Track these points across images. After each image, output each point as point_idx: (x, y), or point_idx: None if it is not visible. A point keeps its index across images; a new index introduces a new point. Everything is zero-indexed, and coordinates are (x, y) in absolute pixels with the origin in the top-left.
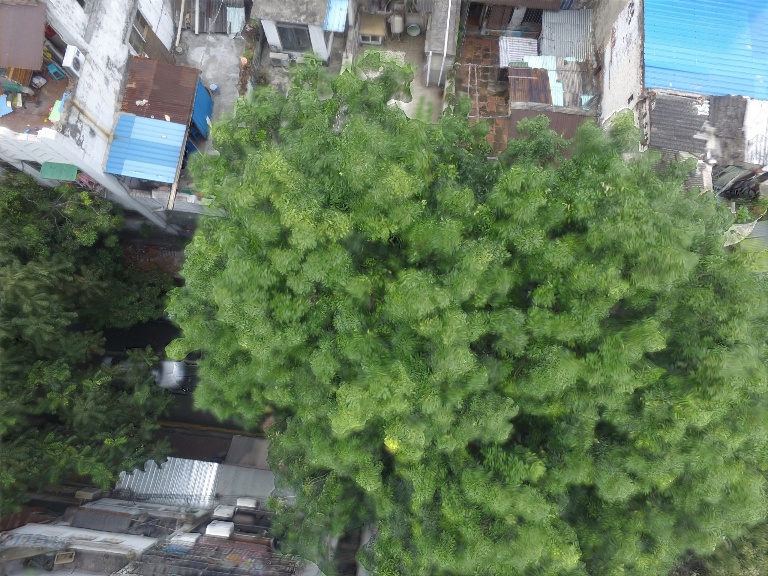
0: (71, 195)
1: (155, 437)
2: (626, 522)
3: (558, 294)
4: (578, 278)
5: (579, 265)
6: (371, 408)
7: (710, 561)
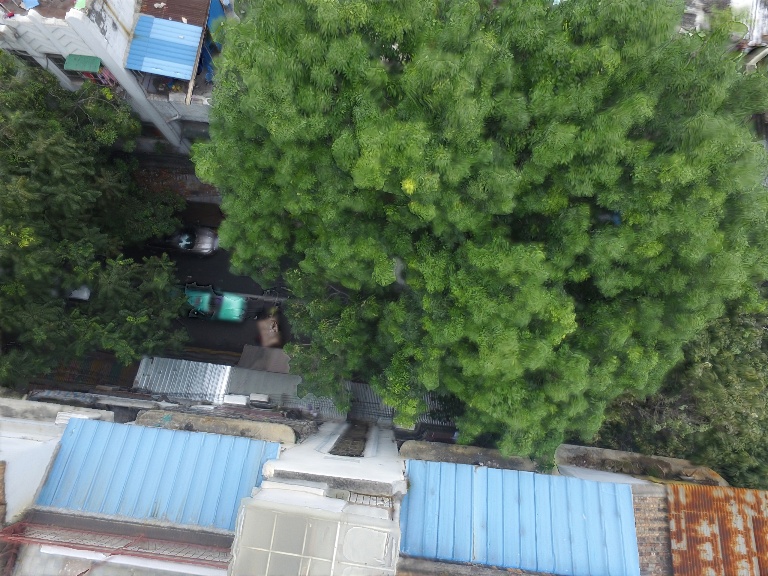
0: (93, 91)
1: (173, 327)
2: (618, 322)
3: (556, 90)
4: (574, 61)
5: (575, 51)
6: (389, 165)
7: (697, 391)
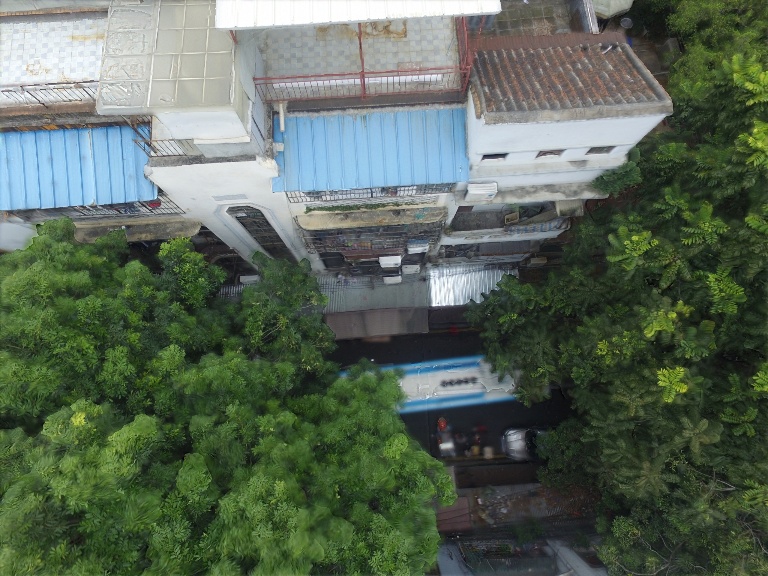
0: None
1: (483, 324)
2: None
3: None
4: None
5: None
6: None
7: None
